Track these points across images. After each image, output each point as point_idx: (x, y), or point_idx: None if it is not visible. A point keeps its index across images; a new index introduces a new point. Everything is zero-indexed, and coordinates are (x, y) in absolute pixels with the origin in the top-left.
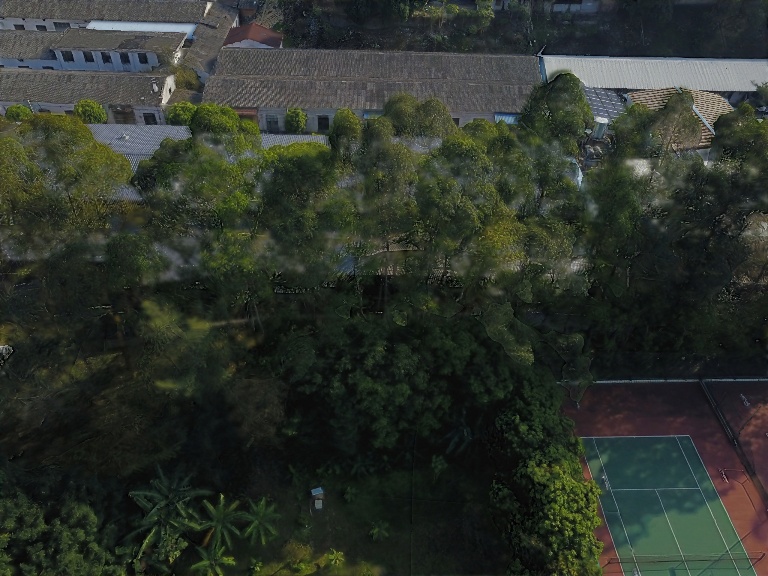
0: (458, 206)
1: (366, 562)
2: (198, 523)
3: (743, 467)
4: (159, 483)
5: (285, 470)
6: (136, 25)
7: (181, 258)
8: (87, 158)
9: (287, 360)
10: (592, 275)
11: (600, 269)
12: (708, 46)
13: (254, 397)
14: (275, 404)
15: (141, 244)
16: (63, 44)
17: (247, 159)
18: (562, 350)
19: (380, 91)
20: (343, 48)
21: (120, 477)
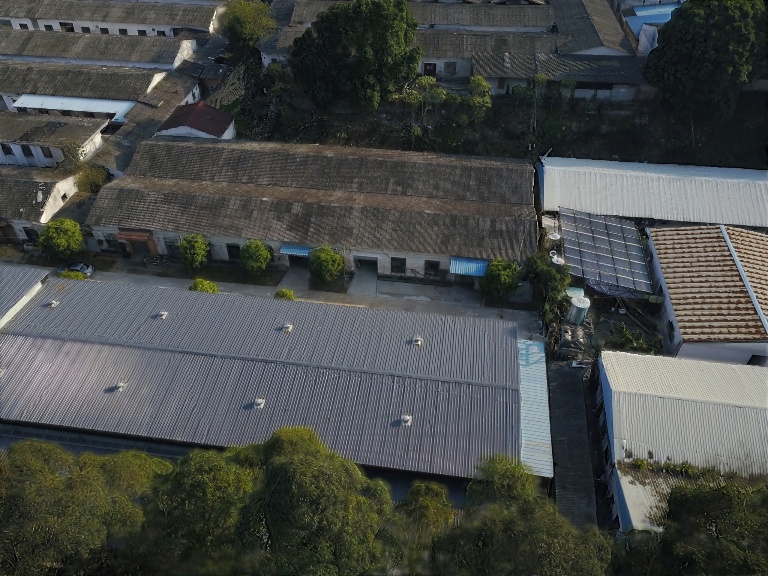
0: None
1: None
2: None
3: None
4: None
5: None
6: (69, 101)
7: None
8: None
9: None
10: None
11: None
12: None
13: None
14: None
15: None
16: None
17: None
18: None
19: (307, 216)
20: (302, 136)
21: None
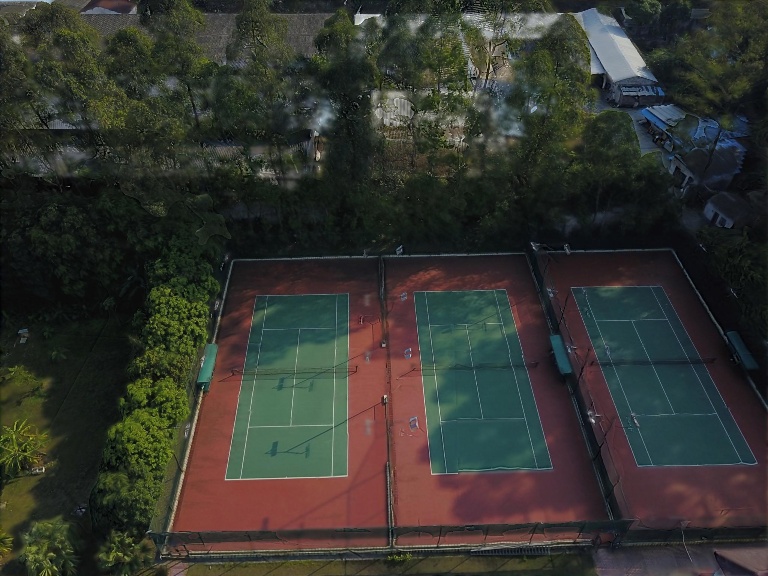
0: (62, 80)
1: (25, 366)
2: None
3: (380, 314)
4: None
5: (0, 315)
6: None
7: None
8: None
9: None
10: (276, 166)
11: (275, 159)
12: None
13: None
14: None
15: None
16: None
17: None
18: (191, 206)
19: None
20: None
21: None
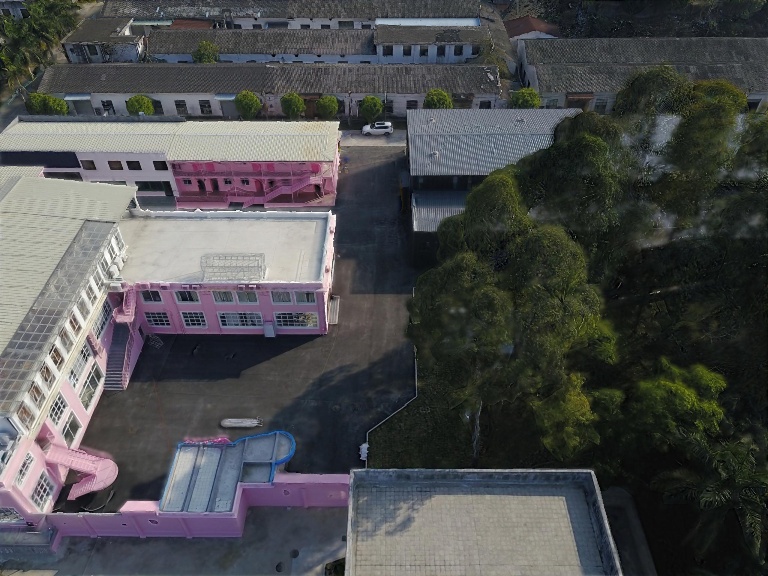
0: None
1: None
2: None
3: None
4: None
5: None
6: (420, 21)
7: None
8: None
9: None
10: None
11: None
12: None
13: None
14: None
15: None
16: (384, 39)
17: None
18: None
19: (704, 73)
20: (616, 37)
21: None
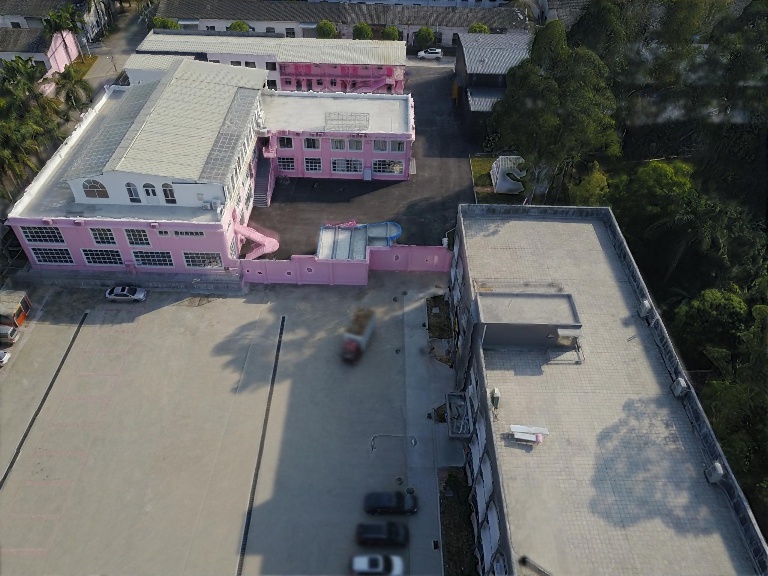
0: None
1: None
2: None
3: None
4: None
5: None
6: None
7: None
8: (734, 4)
9: None
10: None
11: None
12: None
13: None
14: None
15: None
16: None
17: None
18: None
19: None
20: None
21: None
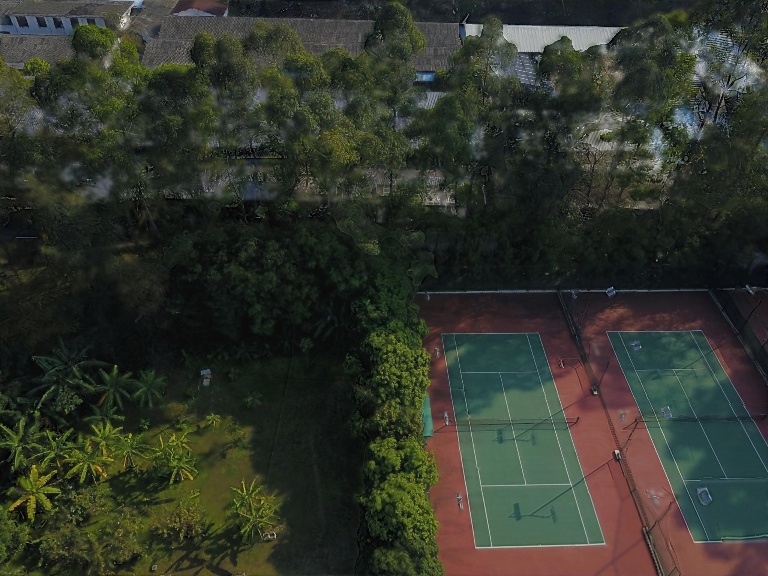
0: (297, 110)
1: None
2: (93, 386)
3: (579, 356)
4: (59, 351)
5: (179, 354)
6: None
7: (74, 158)
8: None
9: (168, 248)
10: None
11: (461, 188)
12: (625, 16)
13: (135, 274)
14: (154, 282)
15: (36, 142)
16: (18, 10)
17: (123, 71)
18: (405, 243)
19: None
20: None
21: (27, 346)
